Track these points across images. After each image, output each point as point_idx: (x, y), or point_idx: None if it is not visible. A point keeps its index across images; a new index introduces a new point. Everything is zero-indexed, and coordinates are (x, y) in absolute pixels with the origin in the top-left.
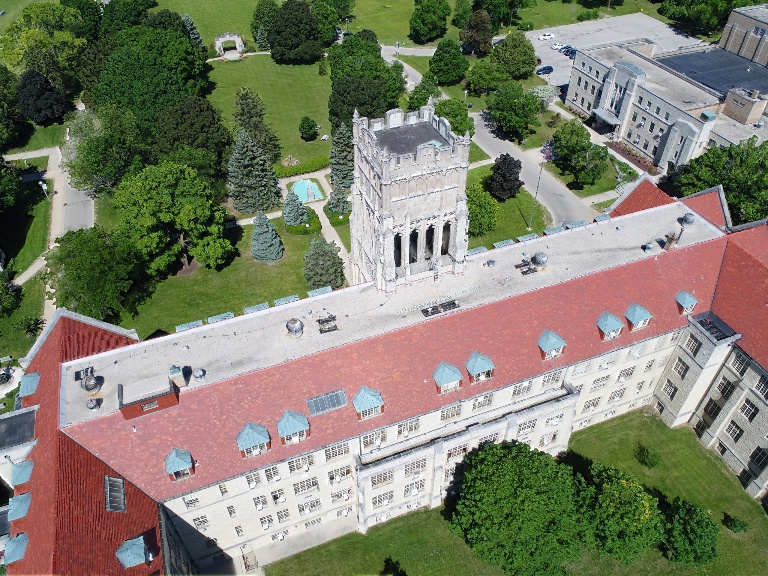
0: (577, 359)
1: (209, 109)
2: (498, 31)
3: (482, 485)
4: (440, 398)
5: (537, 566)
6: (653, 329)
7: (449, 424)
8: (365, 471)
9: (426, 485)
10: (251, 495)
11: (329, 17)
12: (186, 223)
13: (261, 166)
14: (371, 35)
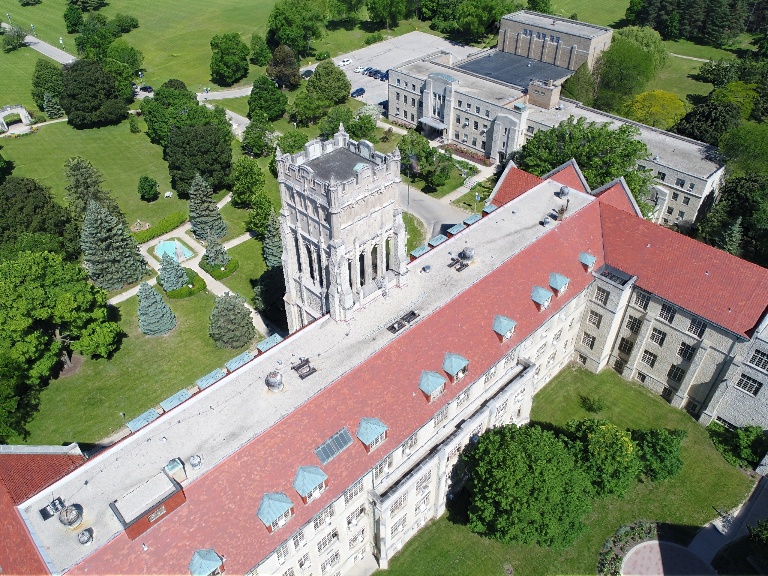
0: (526, 334)
1: (36, 188)
2: (299, 63)
3: (499, 473)
4: (431, 406)
5: (564, 528)
6: (572, 291)
7: (440, 430)
8: (386, 502)
9: (431, 497)
10: (280, 572)
11: (123, 73)
12: (68, 314)
13: (120, 236)
14: (179, 84)
